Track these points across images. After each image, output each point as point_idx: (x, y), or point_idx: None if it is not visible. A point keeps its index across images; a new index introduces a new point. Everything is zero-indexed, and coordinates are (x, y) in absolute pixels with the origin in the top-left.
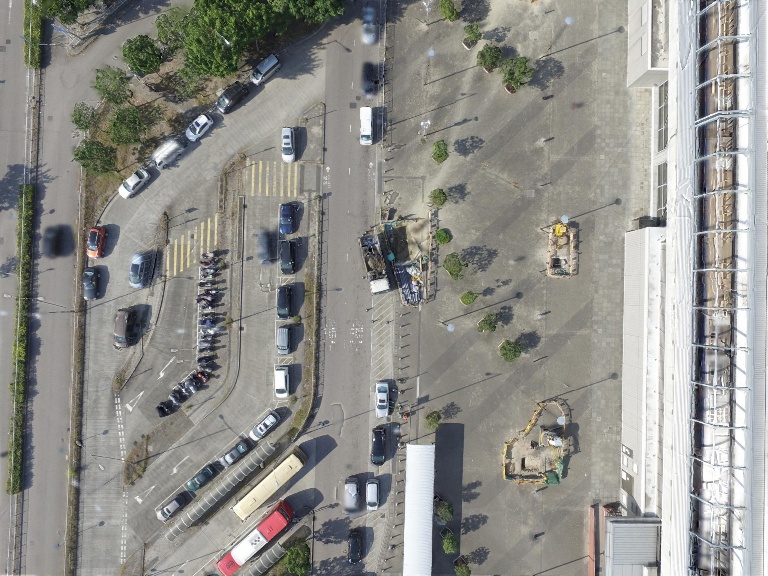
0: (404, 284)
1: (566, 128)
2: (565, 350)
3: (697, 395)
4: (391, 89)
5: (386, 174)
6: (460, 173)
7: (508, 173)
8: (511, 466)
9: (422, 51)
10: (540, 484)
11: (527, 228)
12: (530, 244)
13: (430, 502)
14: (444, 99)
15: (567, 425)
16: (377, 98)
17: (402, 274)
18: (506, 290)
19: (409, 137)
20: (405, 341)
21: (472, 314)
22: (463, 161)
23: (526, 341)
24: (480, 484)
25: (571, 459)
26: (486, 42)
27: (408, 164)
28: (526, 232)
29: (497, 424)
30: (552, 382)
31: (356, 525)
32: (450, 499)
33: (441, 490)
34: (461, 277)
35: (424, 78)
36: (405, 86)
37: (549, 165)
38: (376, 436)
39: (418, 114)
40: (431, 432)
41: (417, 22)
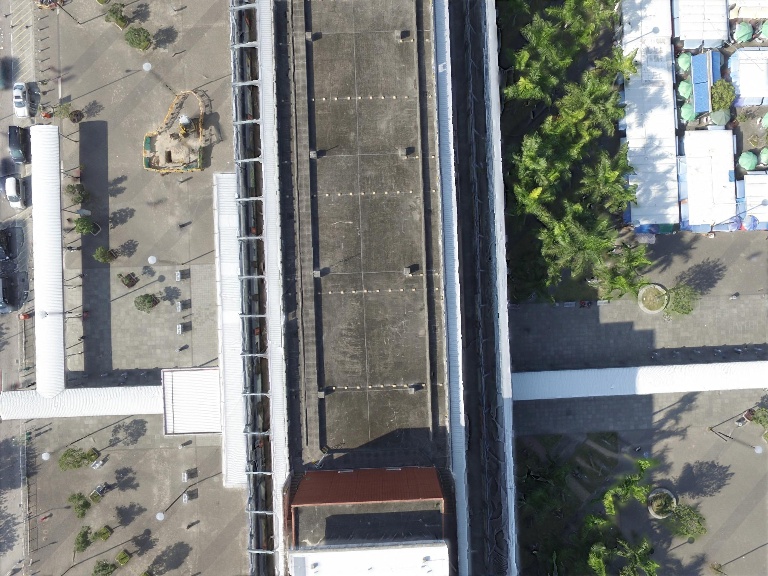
0: None
1: None
2: (202, 43)
3: None
4: None
5: None
6: None
7: None
8: (154, 158)
9: None
10: (184, 175)
11: None
12: None
13: (55, 181)
14: None
15: (208, 115)
16: None
17: None
18: None
19: None
20: (45, 44)
21: None
22: None
23: (164, 37)
24: (126, 179)
25: (213, 148)
26: None
27: None
28: None
29: (139, 119)
30: (191, 75)
31: (5, 226)
32: (97, 195)
33: (88, 187)
34: None
35: None
36: None
37: None
38: (10, 129)
39: None
40: (75, 131)
41: None
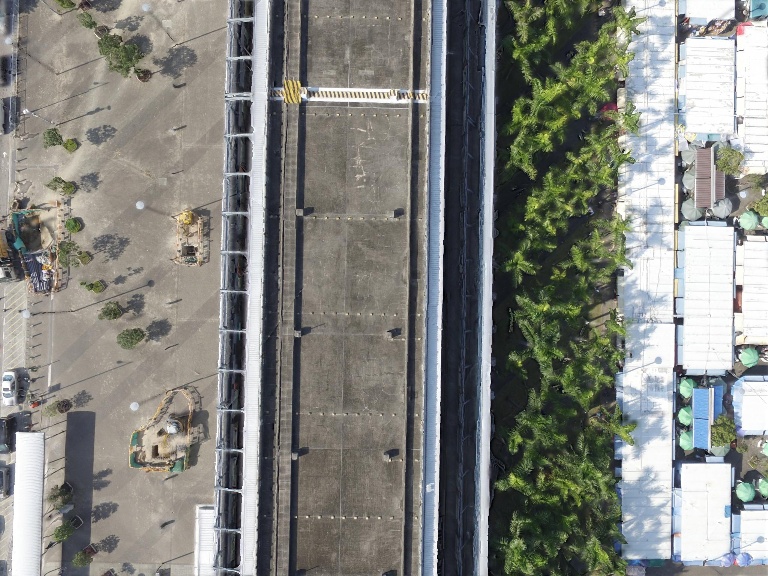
0: (32, 273)
1: (198, 116)
2: (196, 338)
3: (237, 379)
4: (24, 79)
5: (19, 163)
6: (92, 162)
7: (140, 161)
8: (140, 454)
9: (55, 41)
10: (170, 472)
11: (159, 216)
12: (162, 232)
13: (38, 489)
14: (77, 88)
15: (197, 413)
16: (10, 88)
17: (30, 263)
18: (138, 278)
19: (42, 126)
20: (37, 330)
21: (104, 302)
22: (96, 150)
23: (157, 329)
24: (111, 472)
25: (201, 447)
26: (119, 31)
27: (41, 153)
28: (158, 220)
29: (128, 412)
30: (183, 370)
31: None
32: (81, 487)
33: (72, 478)
34: (76, 265)
35: (57, 67)
36: (38, 76)
37: (181, 153)
38: None
39: (51, 103)
40: (62, 420)
41: (50, 12)
